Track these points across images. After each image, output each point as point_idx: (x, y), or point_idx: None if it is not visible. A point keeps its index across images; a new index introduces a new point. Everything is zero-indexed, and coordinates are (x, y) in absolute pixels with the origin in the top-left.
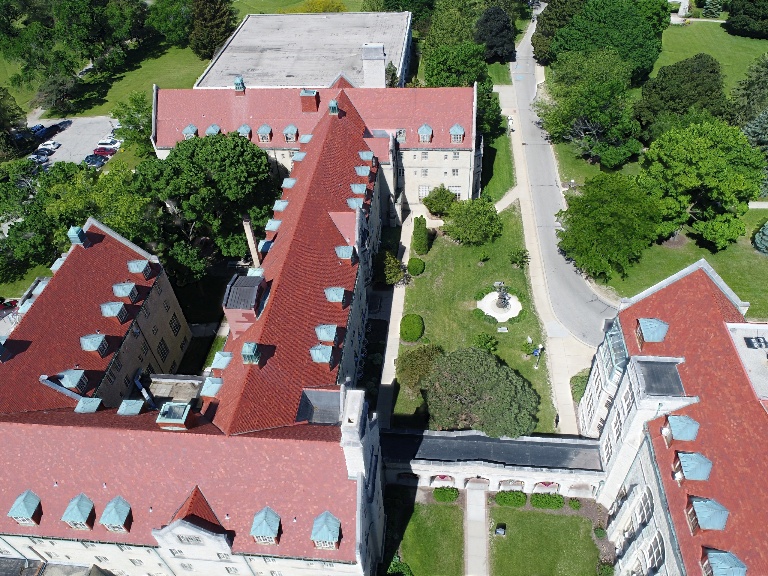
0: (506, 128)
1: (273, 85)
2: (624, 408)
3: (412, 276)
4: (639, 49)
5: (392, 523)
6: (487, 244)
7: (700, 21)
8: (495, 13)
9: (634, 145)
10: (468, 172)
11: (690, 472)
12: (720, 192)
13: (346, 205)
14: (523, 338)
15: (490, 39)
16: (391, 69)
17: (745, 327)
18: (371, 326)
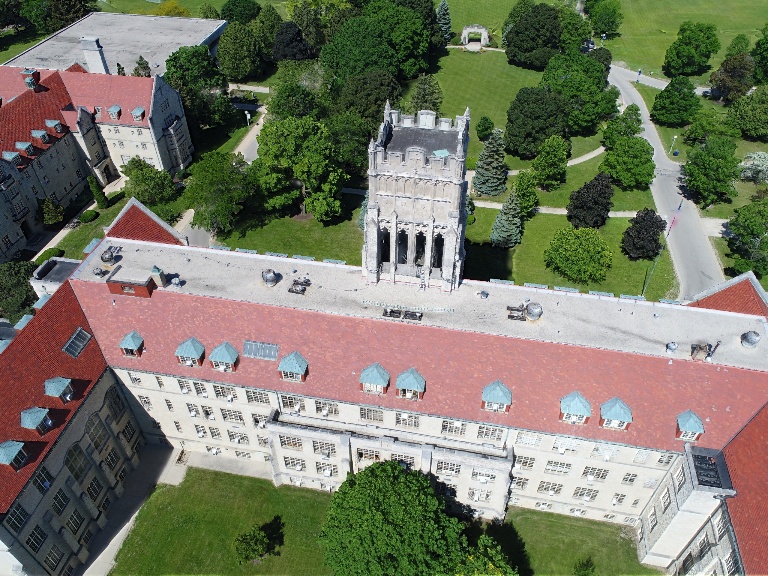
0: (253, 122)
1: (63, 69)
2: None
3: (82, 223)
4: (375, 65)
5: None
6: (159, 206)
7: (495, 51)
8: (288, 27)
9: None
10: (153, 147)
11: (18, 324)
12: (295, 172)
13: None
14: None
15: (282, 49)
16: (141, 62)
17: (117, 240)
18: (21, 254)
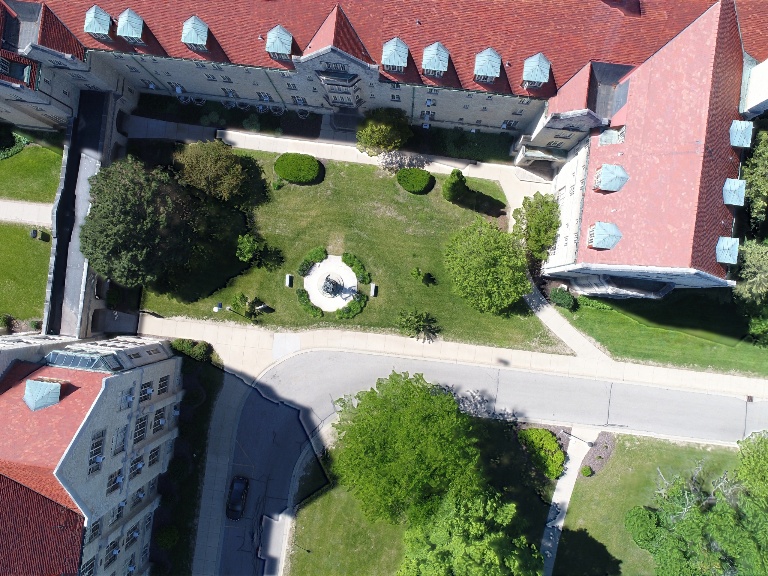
0: None
1: None
2: (1, 344)
3: None
4: None
5: (53, 137)
6: None
7: None
8: None
9: (670, 575)
10: (564, 262)
11: None
12: None
13: (383, 38)
14: (274, 303)
15: None
16: None
17: None
18: (308, 118)
